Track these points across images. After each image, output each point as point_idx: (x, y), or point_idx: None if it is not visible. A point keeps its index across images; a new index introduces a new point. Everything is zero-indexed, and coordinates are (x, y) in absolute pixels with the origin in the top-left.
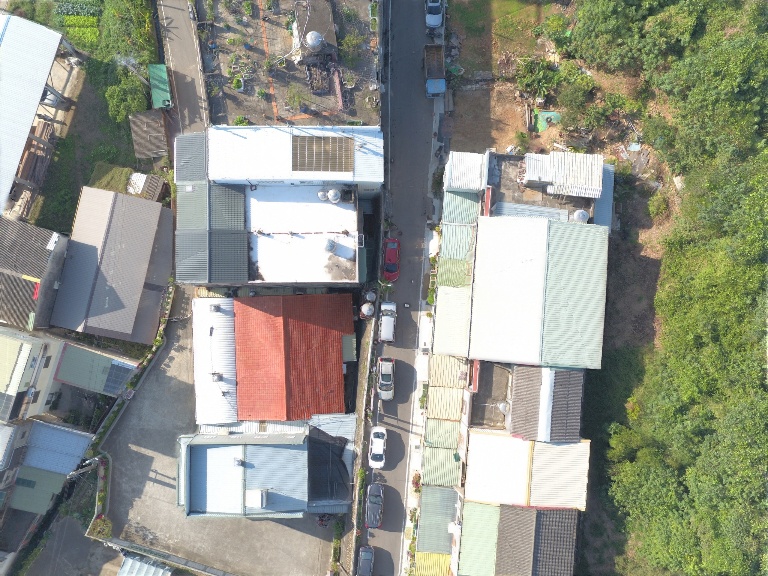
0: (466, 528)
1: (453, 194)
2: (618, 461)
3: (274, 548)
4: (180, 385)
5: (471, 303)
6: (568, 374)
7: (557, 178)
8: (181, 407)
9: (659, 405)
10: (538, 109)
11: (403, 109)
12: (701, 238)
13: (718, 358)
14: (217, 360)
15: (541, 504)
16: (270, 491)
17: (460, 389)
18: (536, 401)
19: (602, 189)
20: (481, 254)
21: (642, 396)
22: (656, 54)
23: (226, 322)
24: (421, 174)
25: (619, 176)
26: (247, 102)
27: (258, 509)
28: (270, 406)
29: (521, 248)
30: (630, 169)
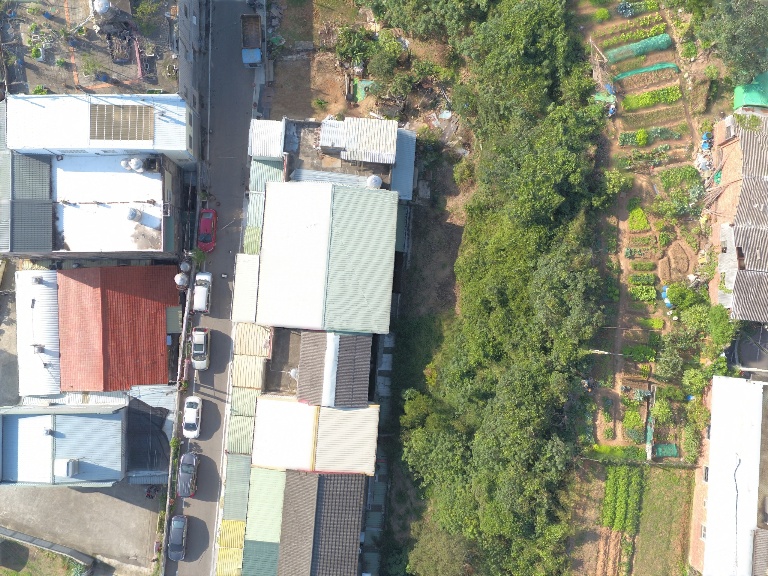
0: (253, 493)
1: (260, 163)
2: (411, 427)
3: (104, 520)
4: (10, 358)
5: (258, 269)
6: (354, 339)
7: (350, 144)
8: (11, 380)
9: (449, 370)
10: (358, 79)
11: (223, 80)
12: (498, 203)
13: (502, 322)
14: (40, 332)
15: (326, 469)
16: (82, 461)
17: (266, 357)
18: (321, 366)
19: (401, 155)
20: (269, 220)
21: (440, 362)
22: (456, 19)
23: (49, 294)
24: (240, 145)
25: (427, 143)
26: (48, 71)
27: (68, 478)
28: (89, 377)
29: (306, 213)
30: (440, 137)
